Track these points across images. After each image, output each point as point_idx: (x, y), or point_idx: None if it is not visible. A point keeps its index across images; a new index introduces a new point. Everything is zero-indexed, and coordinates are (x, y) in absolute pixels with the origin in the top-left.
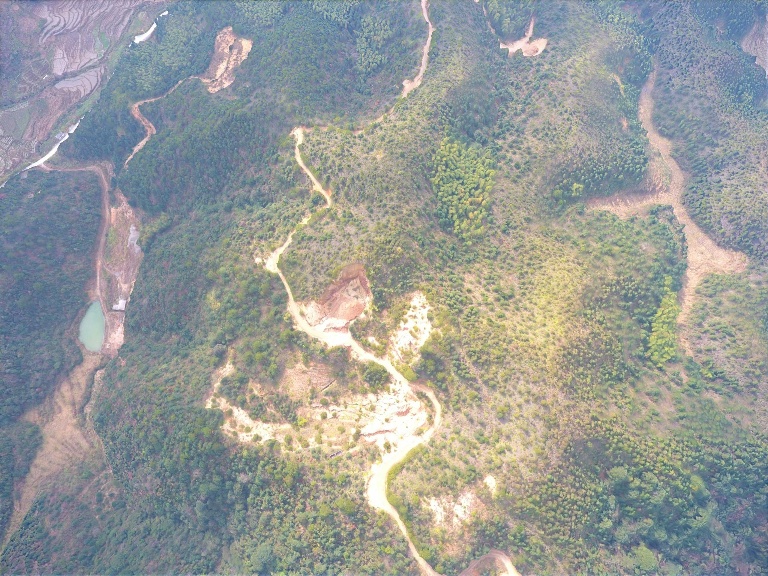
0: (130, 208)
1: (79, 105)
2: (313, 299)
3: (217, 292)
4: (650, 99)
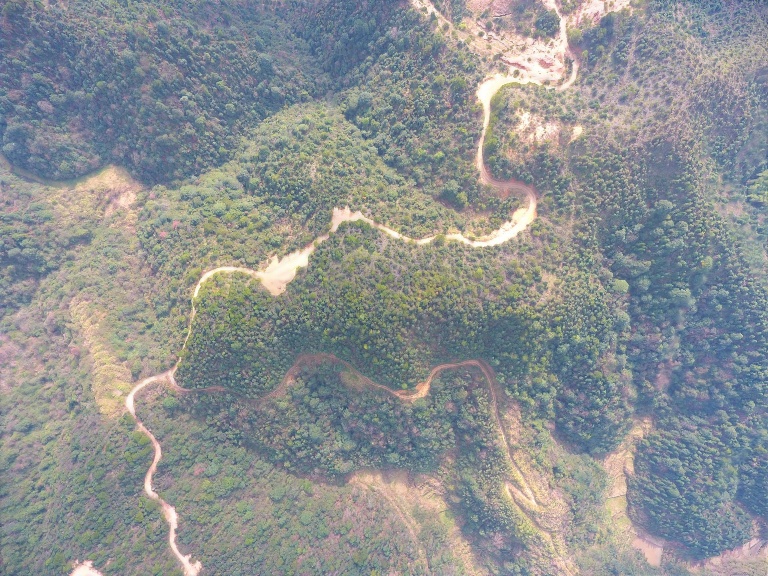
0: None
1: None
2: None
3: None
4: None
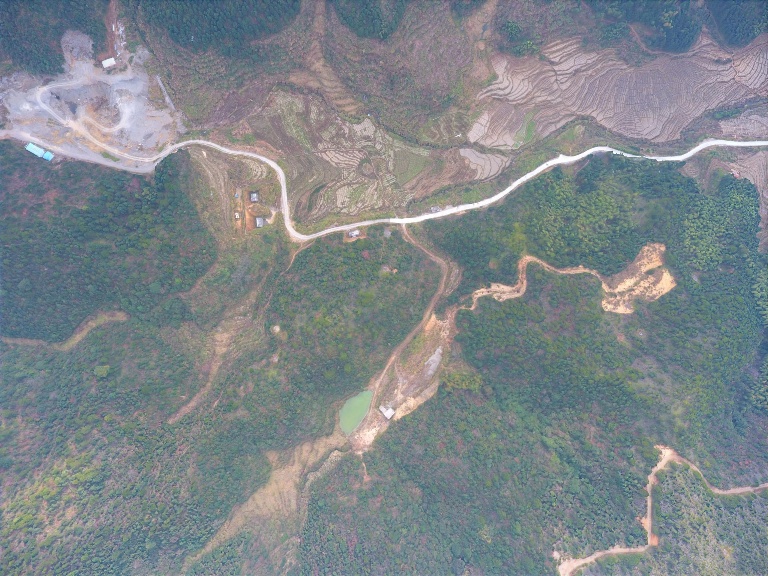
0: (449, 330)
1: (469, 189)
2: None
3: (496, 531)
4: None
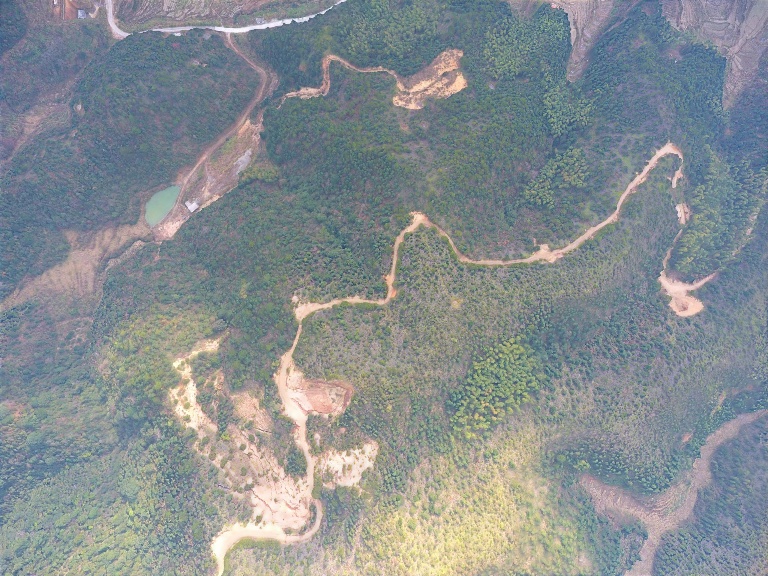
0: None
1: (296, 4)
2: (303, 372)
3: (251, 286)
4: (736, 429)
